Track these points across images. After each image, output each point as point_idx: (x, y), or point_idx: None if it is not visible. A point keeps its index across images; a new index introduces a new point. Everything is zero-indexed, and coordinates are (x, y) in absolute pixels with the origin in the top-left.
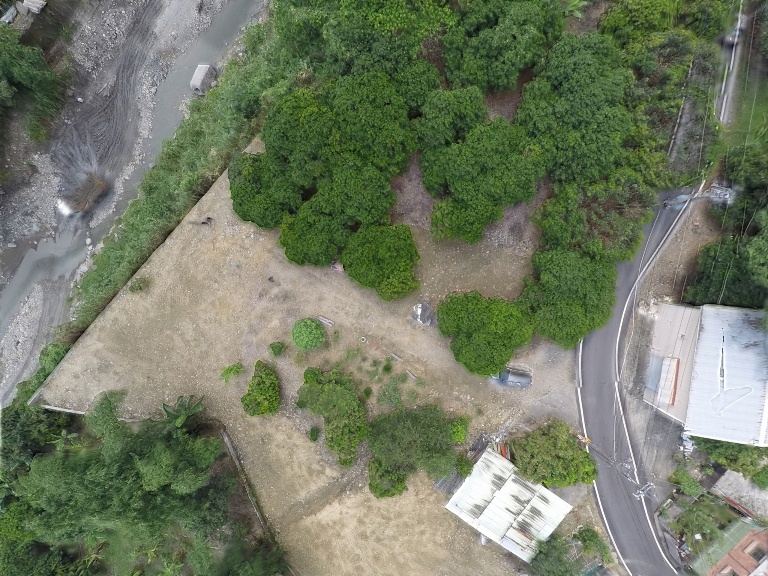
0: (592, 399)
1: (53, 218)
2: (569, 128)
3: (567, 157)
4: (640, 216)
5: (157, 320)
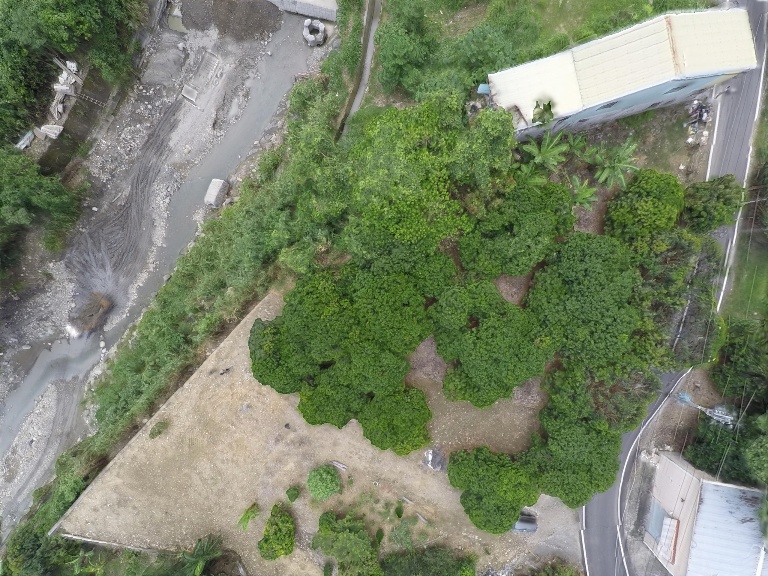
0: (595, 541)
1: (67, 321)
2: (579, 323)
3: (576, 347)
4: (645, 400)
5: (175, 460)
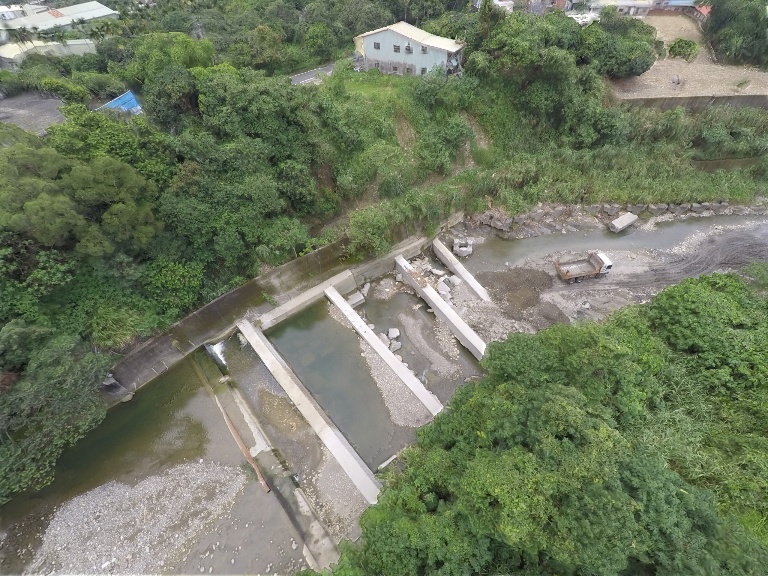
0: None
1: None
2: None
3: None
4: None
5: None
